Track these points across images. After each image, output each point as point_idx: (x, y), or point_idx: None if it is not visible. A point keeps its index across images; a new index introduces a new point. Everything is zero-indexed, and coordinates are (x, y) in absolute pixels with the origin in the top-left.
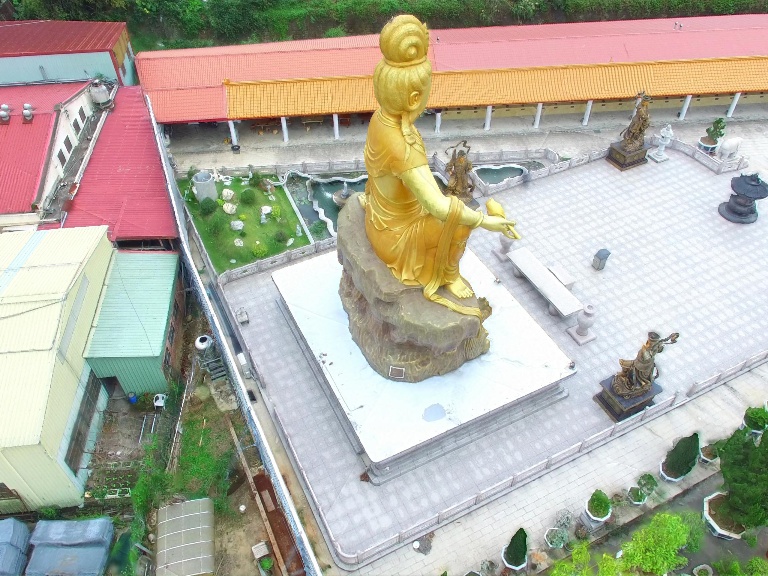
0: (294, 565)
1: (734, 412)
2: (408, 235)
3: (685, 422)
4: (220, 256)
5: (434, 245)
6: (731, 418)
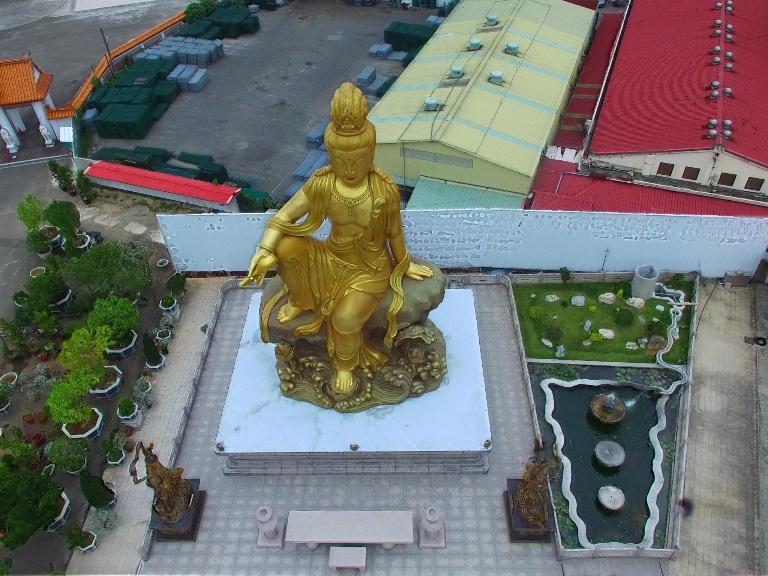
0: None
1: None
2: None
3: (126, 560)
4: (547, 290)
5: None
6: None
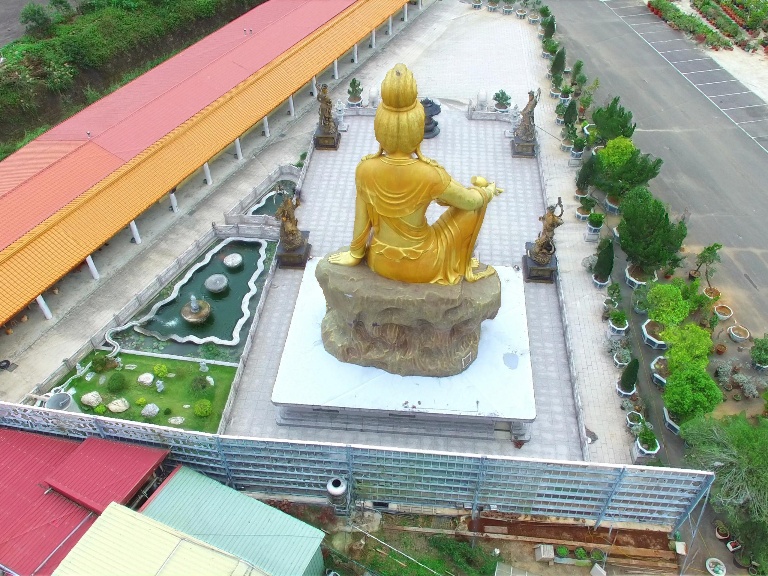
0: (565, 535)
1: (572, 231)
2: (445, 244)
3: (567, 254)
4: None
5: (469, 235)
6: (575, 235)
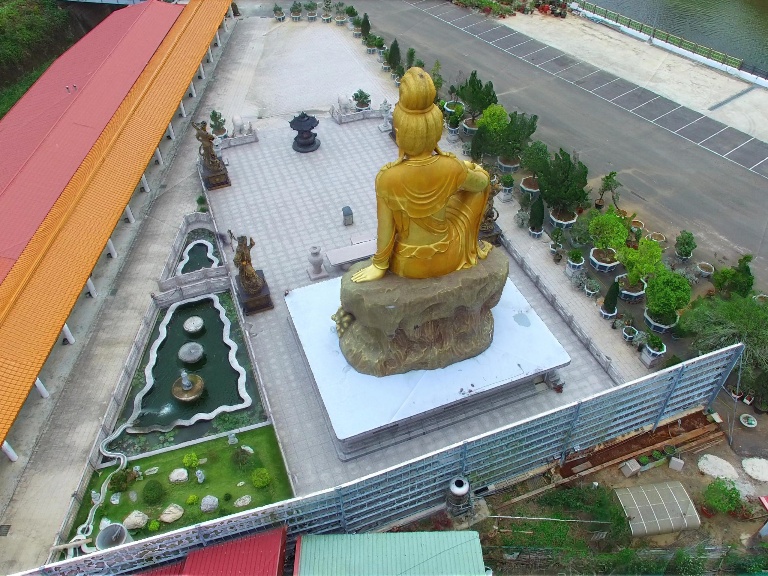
0: (634, 446)
1: None
2: (464, 229)
3: None
4: None
5: None
6: None
